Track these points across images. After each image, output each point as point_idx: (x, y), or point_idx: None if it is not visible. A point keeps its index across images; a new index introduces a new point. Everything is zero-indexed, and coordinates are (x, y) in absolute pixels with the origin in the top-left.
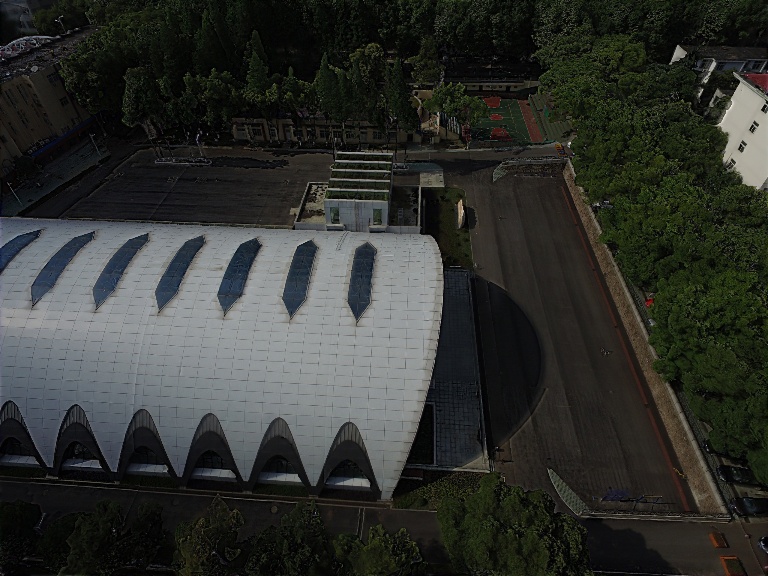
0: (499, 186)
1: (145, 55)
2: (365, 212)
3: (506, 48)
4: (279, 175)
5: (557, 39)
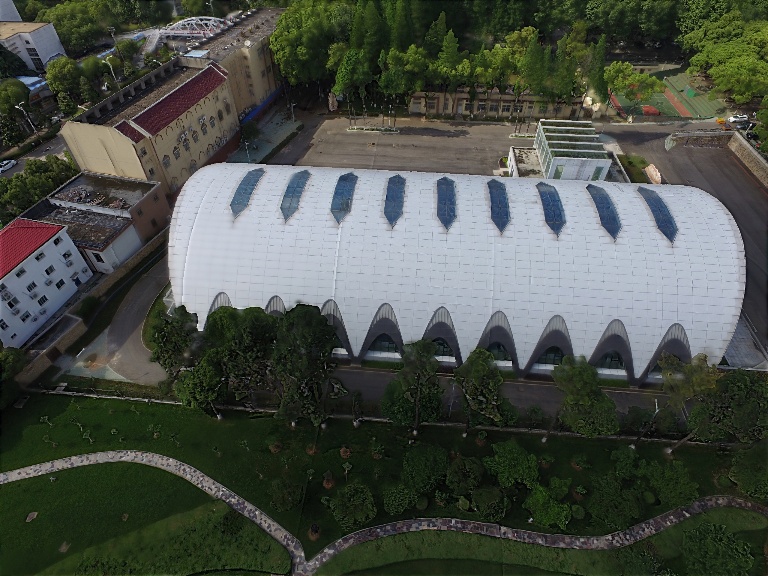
0: (674, 155)
1: (341, 32)
2: (587, 170)
3: (652, 32)
4: (467, 143)
5: (707, 24)
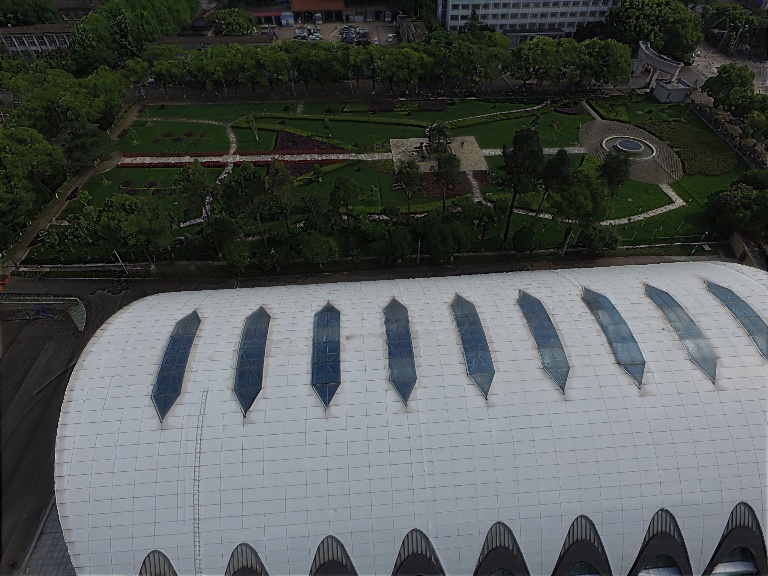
0: None
1: None
2: None
3: None
4: None
5: None
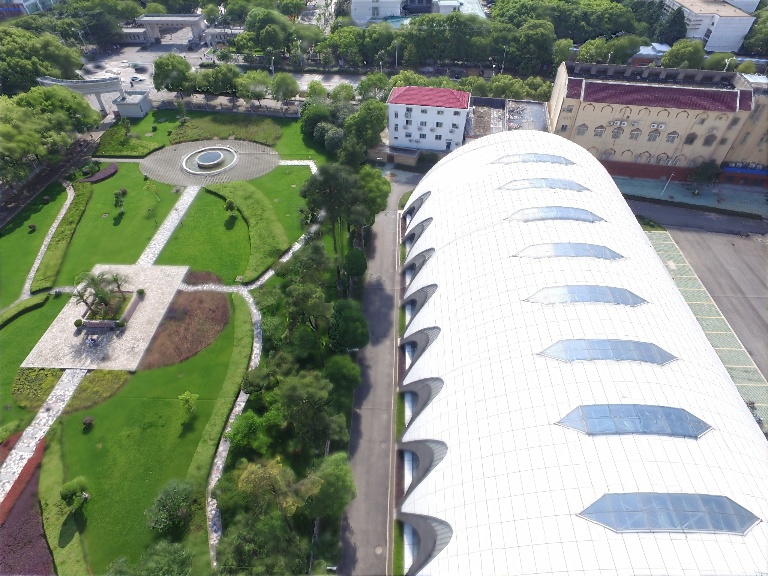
0: None
1: None
2: None
3: None
4: None
5: None
